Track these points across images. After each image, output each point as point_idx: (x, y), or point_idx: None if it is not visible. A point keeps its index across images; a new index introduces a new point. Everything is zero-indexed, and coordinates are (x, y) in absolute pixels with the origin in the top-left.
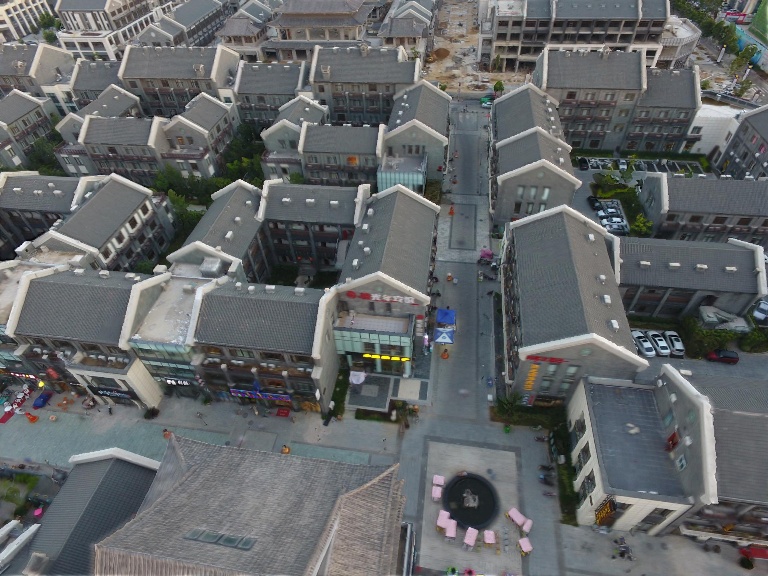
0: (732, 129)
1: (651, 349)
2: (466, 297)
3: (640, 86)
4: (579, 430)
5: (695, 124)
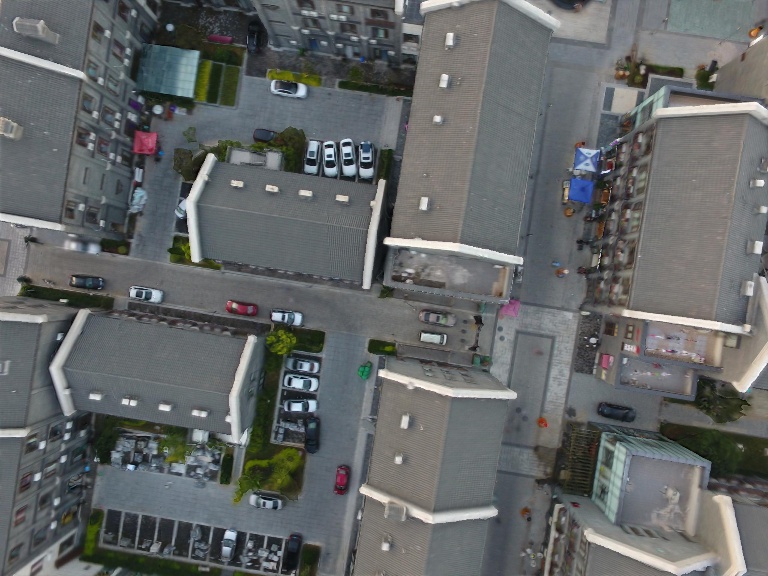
0: None
1: (345, 145)
2: (543, 239)
3: None
4: None
5: None
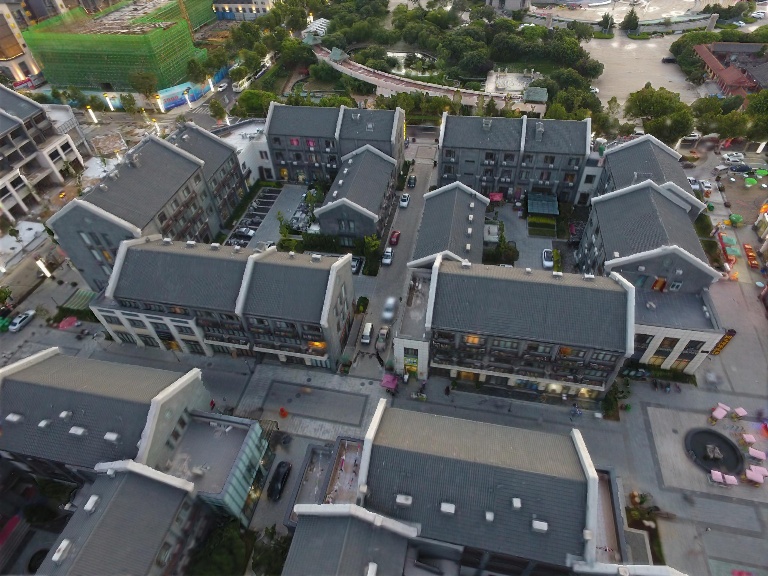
0: (262, 148)
1: None
2: None
3: (196, 164)
4: (641, 345)
5: (241, 163)
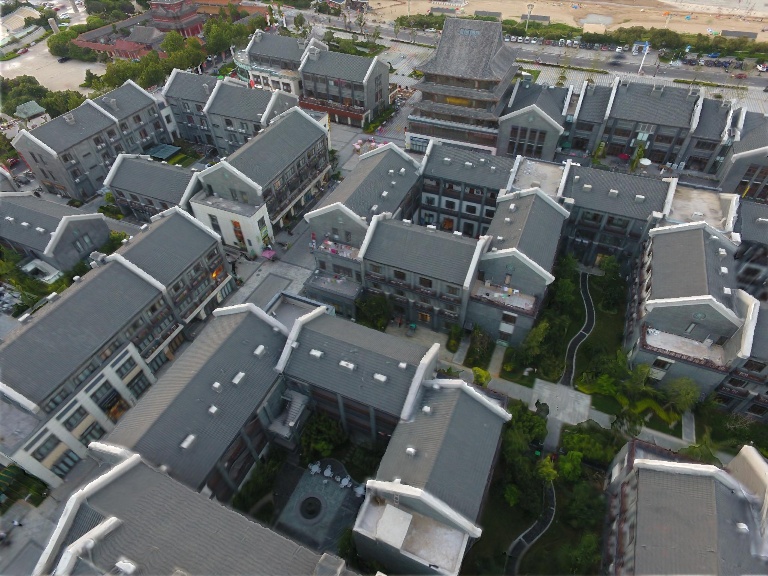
0: None
1: None
2: None
3: None
4: None
5: None
